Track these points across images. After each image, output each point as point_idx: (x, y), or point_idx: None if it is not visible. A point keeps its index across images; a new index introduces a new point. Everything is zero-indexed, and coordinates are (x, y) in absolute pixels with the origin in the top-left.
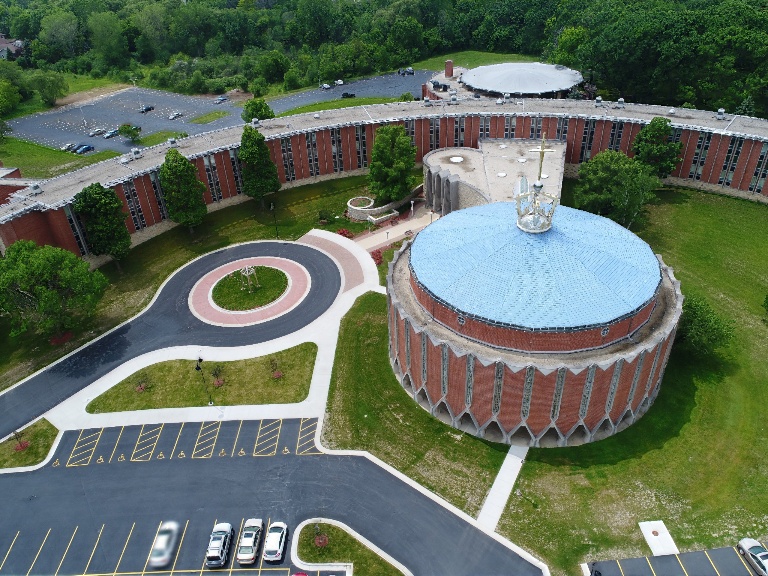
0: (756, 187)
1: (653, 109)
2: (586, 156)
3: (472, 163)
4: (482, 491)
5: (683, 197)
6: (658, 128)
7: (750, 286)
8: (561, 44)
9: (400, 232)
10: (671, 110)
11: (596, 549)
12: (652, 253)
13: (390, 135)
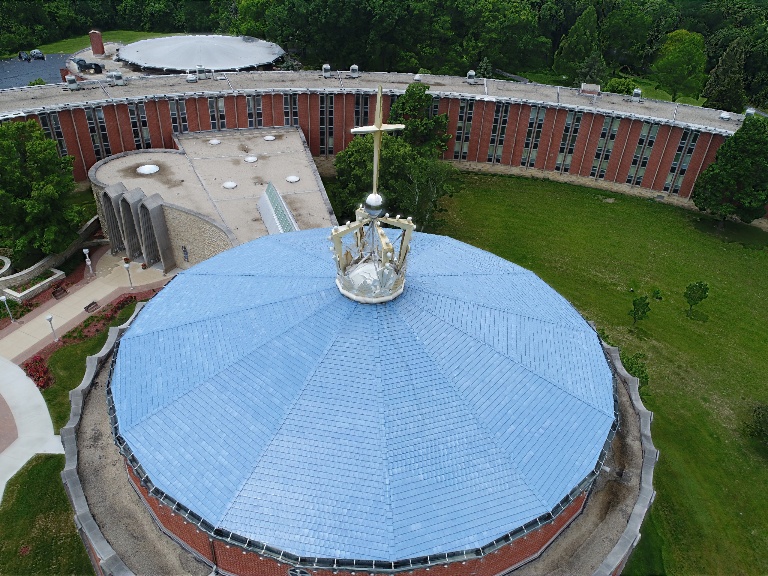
0: (529, 160)
1: (394, 77)
2: (328, 145)
3: (175, 172)
4: None
5: (457, 183)
6: (418, 98)
7: (589, 286)
8: (243, 10)
9: (75, 309)
10: (416, 76)
11: None
12: (549, 287)
13: (13, 140)
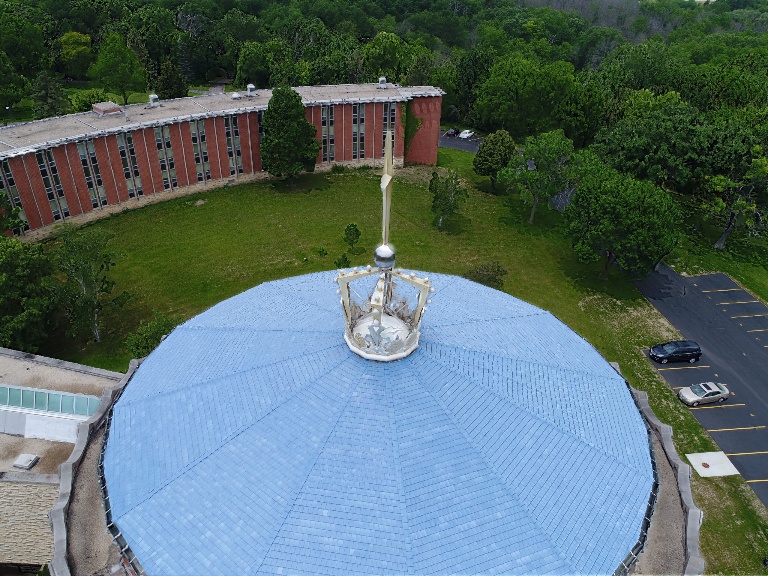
0: (100, 200)
1: None
2: None
3: None
4: None
5: None
6: None
7: (279, 275)
8: None
9: None
10: None
11: (767, 528)
12: None
13: None
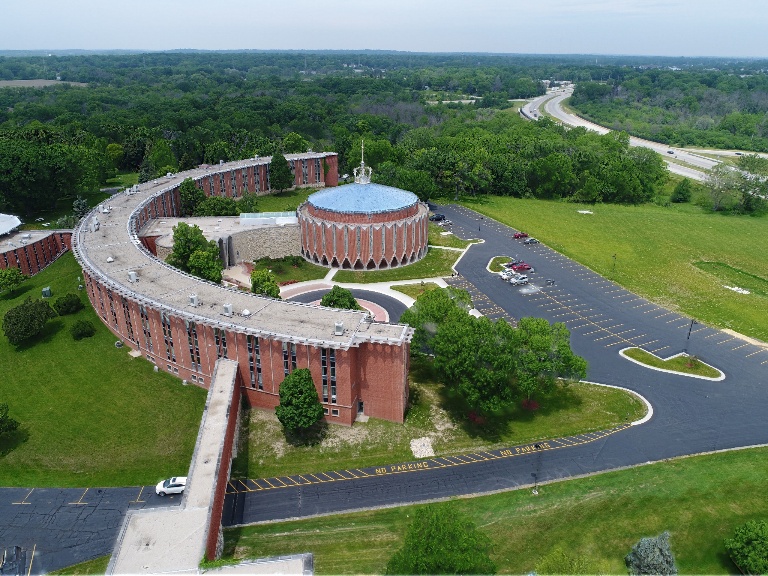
0: None
1: (145, 186)
2: None
3: None
4: (452, 250)
5: None
6: None
7: None
8: None
9: None
10: (156, 182)
11: None
12: None
13: None
